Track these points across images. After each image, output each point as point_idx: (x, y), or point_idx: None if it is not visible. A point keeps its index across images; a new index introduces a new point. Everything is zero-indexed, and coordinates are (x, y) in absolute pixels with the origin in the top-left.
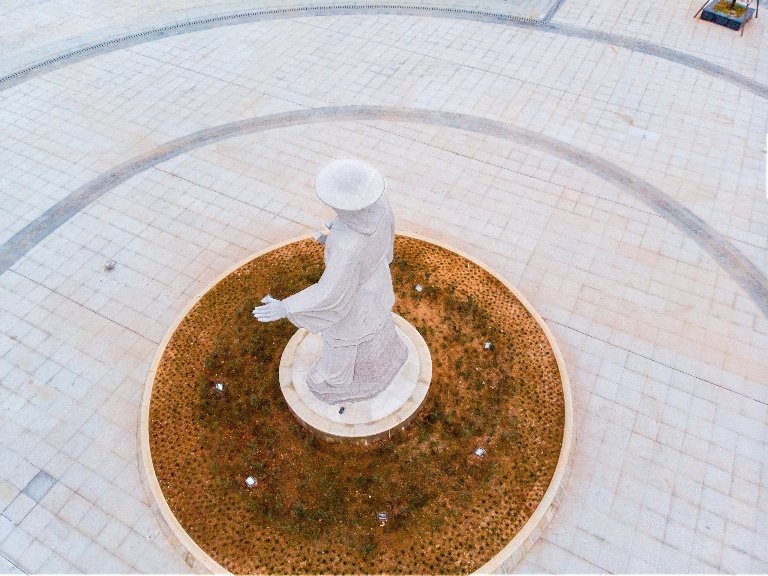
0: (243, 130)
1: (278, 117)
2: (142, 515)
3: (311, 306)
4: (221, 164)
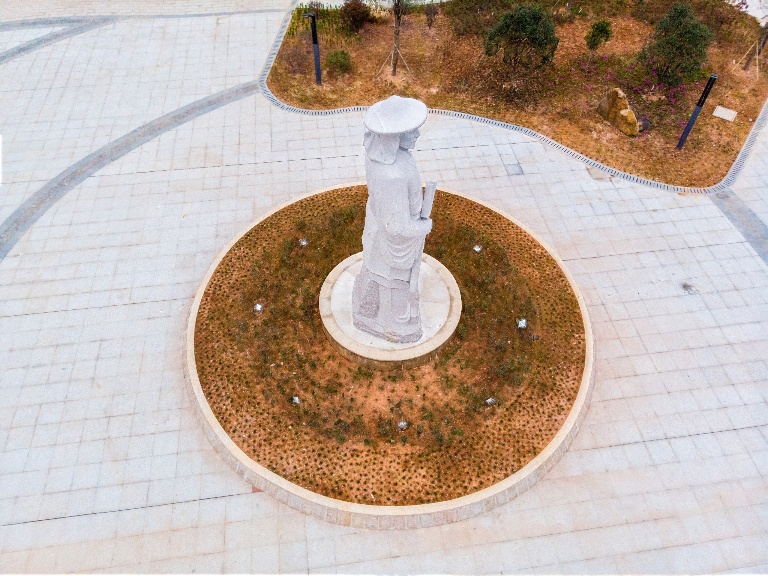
0: None
1: None
2: None
3: None
4: None
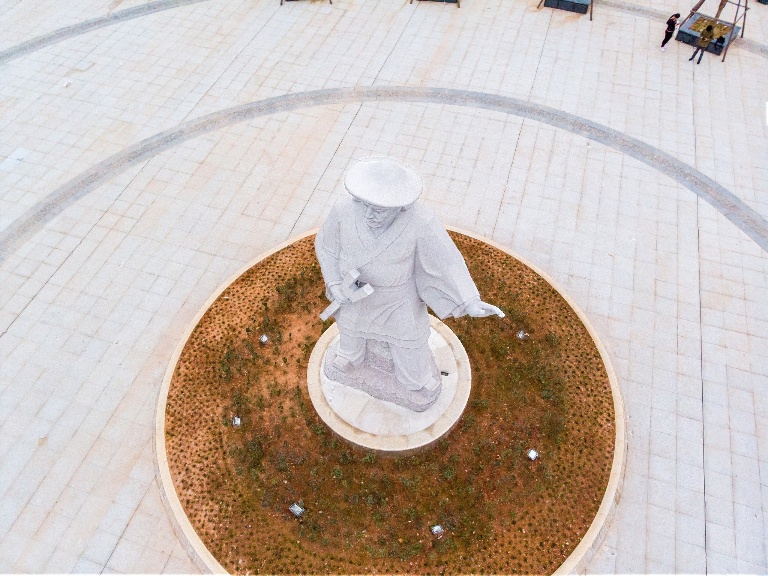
0: None
1: None
2: (598, 575)
3: None
4: None
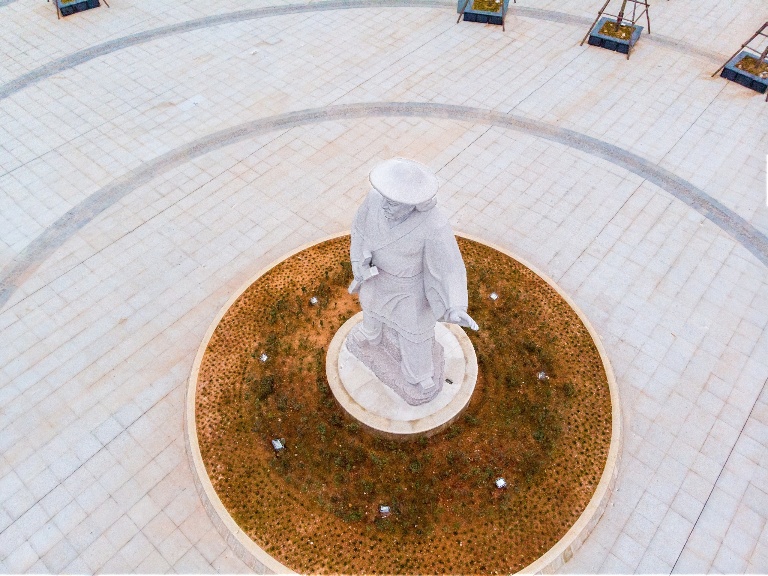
0: None
1: None
2: None
3: None
4: None
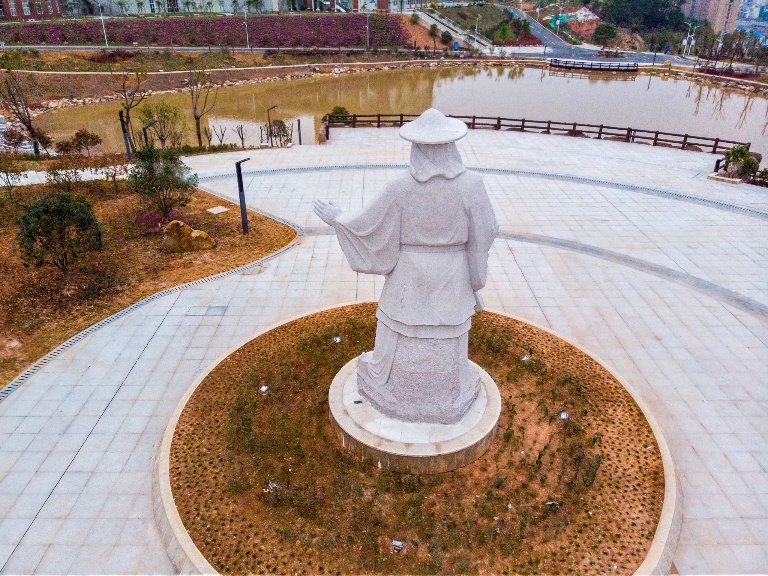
0: (602, 255)
1: (646, 264)
2: None
3: (347, 221)
4: (551, 261)
